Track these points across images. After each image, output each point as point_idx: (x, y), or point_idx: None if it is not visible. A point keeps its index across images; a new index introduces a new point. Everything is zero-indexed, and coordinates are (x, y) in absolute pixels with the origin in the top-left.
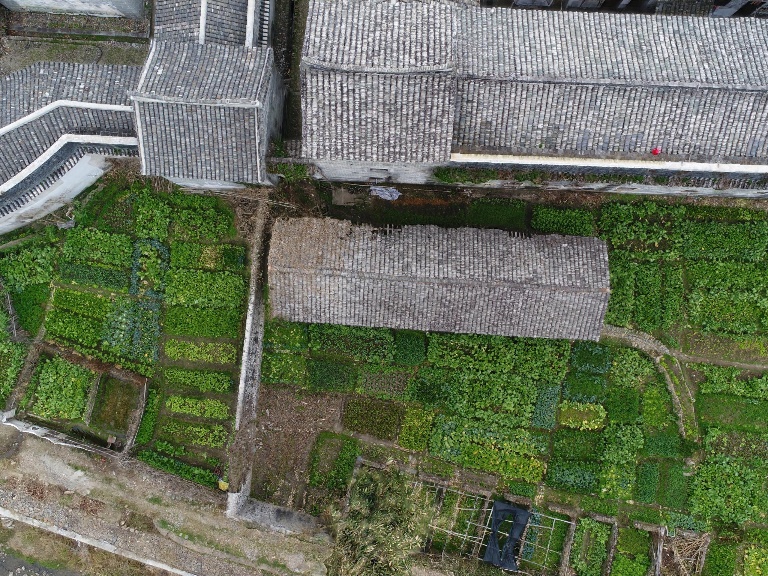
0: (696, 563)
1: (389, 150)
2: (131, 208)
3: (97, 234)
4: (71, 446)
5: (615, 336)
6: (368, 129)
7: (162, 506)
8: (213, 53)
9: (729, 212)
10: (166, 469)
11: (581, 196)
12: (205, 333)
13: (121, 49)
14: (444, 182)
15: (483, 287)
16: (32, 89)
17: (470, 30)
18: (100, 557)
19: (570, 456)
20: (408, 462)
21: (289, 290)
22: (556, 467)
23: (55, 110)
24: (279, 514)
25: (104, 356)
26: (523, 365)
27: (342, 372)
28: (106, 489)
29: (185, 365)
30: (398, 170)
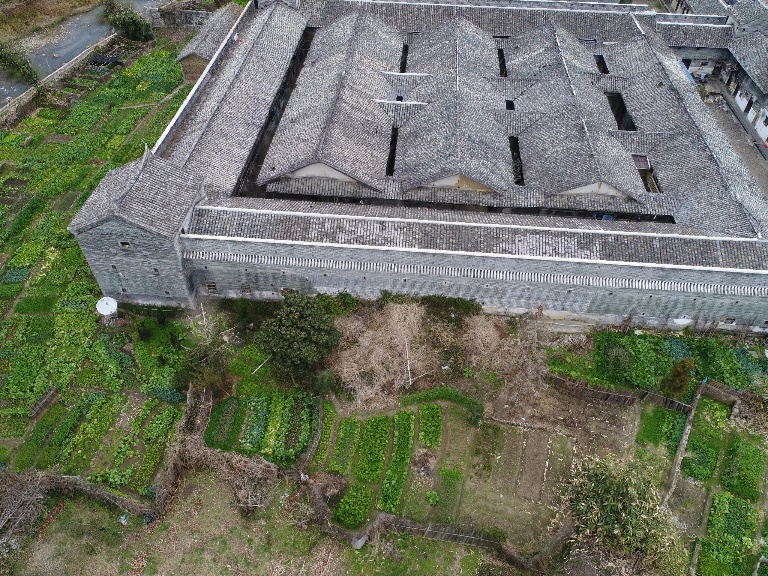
0: None
1: None
2: None
3: None
4: None
5: None
6: None
7: None
8: None
9: None
10: None
11: None
12: None
13: None
14: None
15: None
16: None
17: None
18: None
19: None
20: (148, 53)
21: None
22: None
23: None
24: None
25: None
26: None
27: None
28: None
29: None
30: None
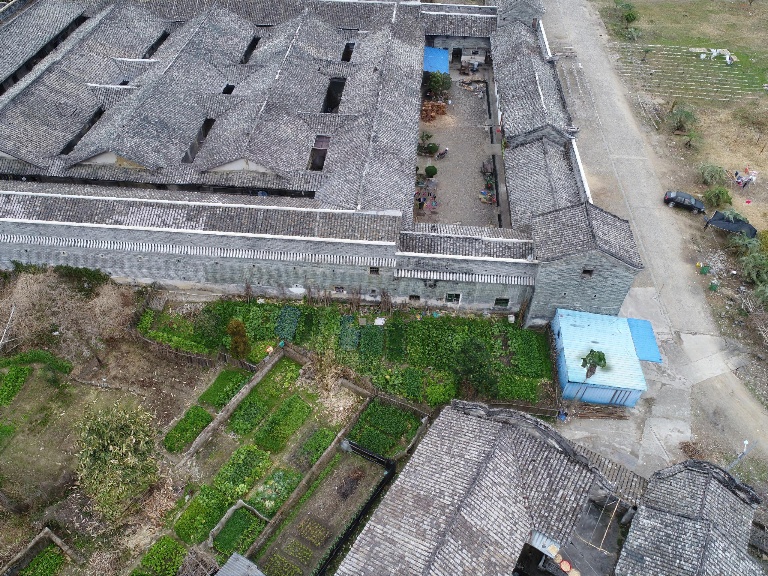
0: None
1: None
2: None
3: None
4: None
5: None
6: None
7: None
8: None
9: None
10: None
11: None
12: None
13: None
14: None
15: None
16: None
17: (73, 5)
18: None
19: None
20: None
21: None
22: None
23: None
24: None
25: None
26: None
27: None
28: None
29: None
30: None
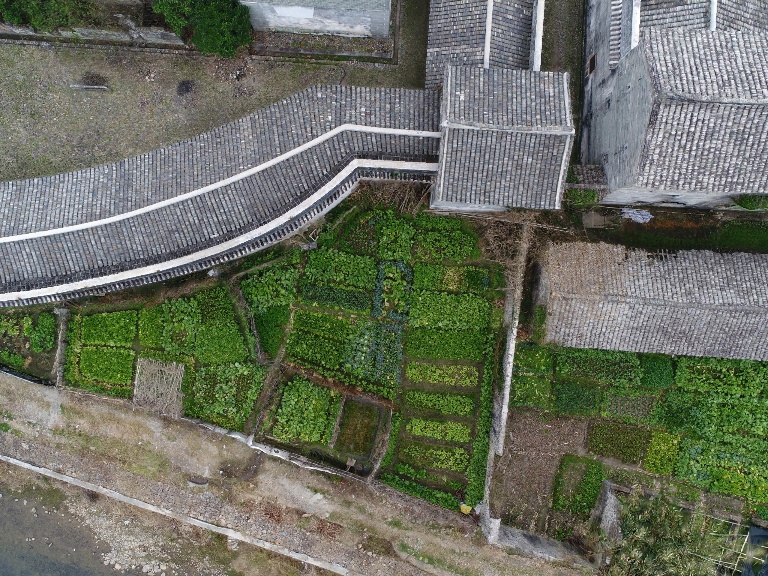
0: None
1: (726, 180)
2: (373, 229)
3: (340, 256)
4: (310, 469)
5: None
6: (709, 159)
7: (401, 529)
8: (510, 78)
9: None
10: (411, 493)
11: None
12: (448, 356)
13: (364, 69)
14: (708, 206)
15: (767, 314)
16: (312, 112)
17: None
18: None
19: None
20: (653, 486)
21: (568, 316)
22: None
23: (339, 134)
24: (529, 539)
25: (346, 378)
26: None
27: (588, 395)
28: (345, 512)
29: (425, 387)
30: (688, 196)
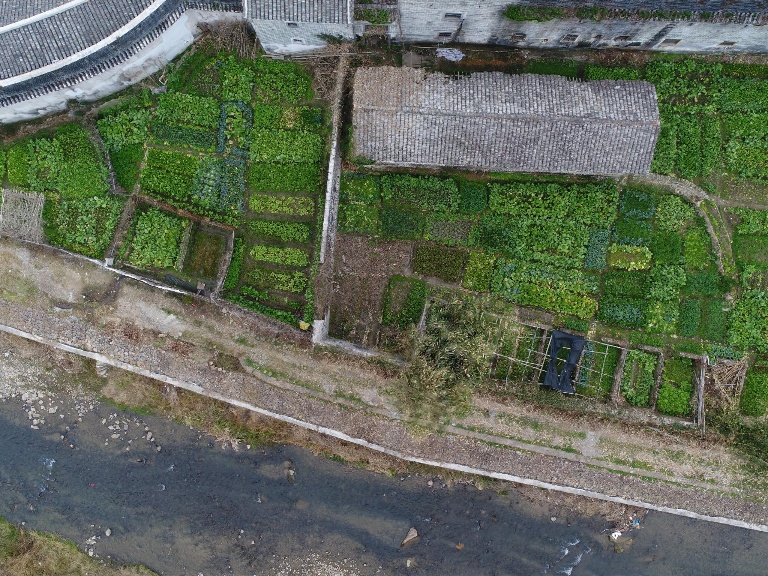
0: (735, 387)
1: None
2: (217, 74)
3: (187, 98)
4: (164, 293)
5: (659, 183)
6: None
7: (247, 346)
8: None
9: (761, 69)
10: (253, 309)
11: (628, 54)
12: (286, 187)
13: None
14: (506, 38)
15: (546, 122)
16: None
17: None
18: (188, 400)
19: (619, 294)
20: (472, 302)
21: (371, 129)
22: (607, 304)
23: None
24: (357, 347)
25: (194, 209)
26: (576, 211)
27: (411, 220)
28: (196, 331)
29: (267, 218)
30: (470, 15)
